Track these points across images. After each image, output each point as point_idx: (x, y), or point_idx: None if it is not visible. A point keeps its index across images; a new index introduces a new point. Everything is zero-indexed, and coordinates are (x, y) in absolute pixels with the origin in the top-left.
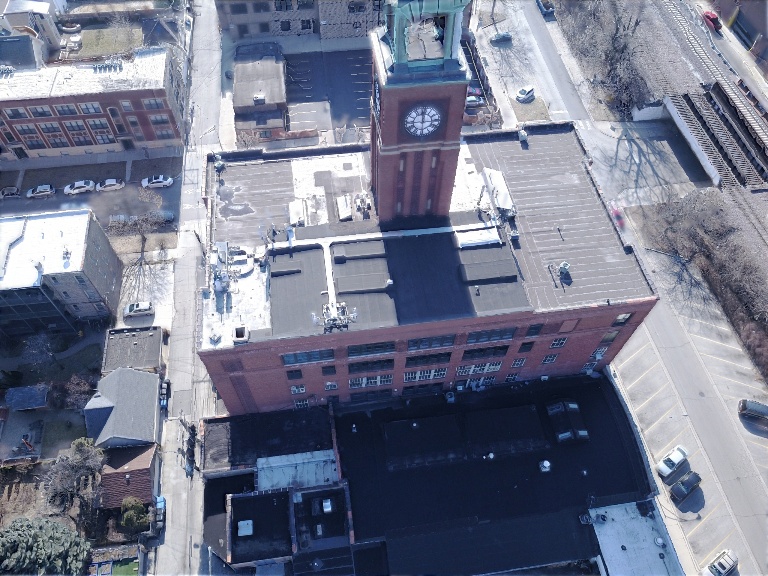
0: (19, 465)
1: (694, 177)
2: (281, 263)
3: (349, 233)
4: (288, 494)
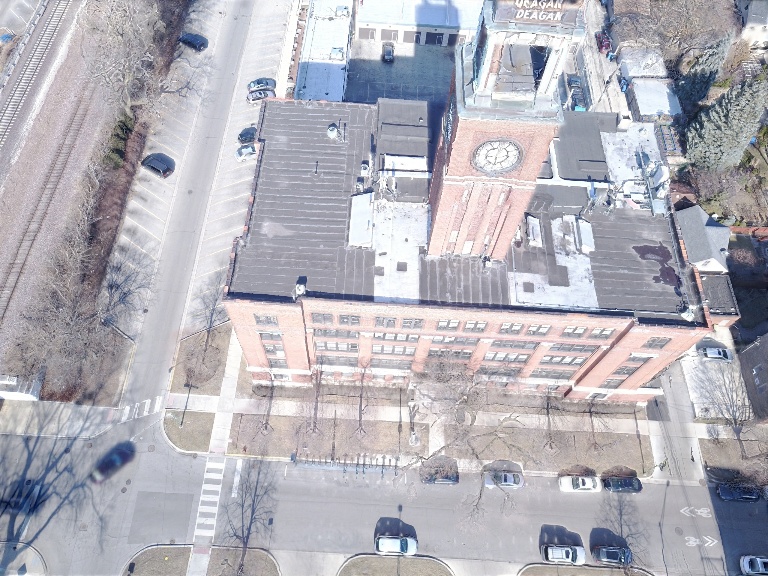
0: (764, 225)
1: None
2: (599, 169)
3: None
4: None
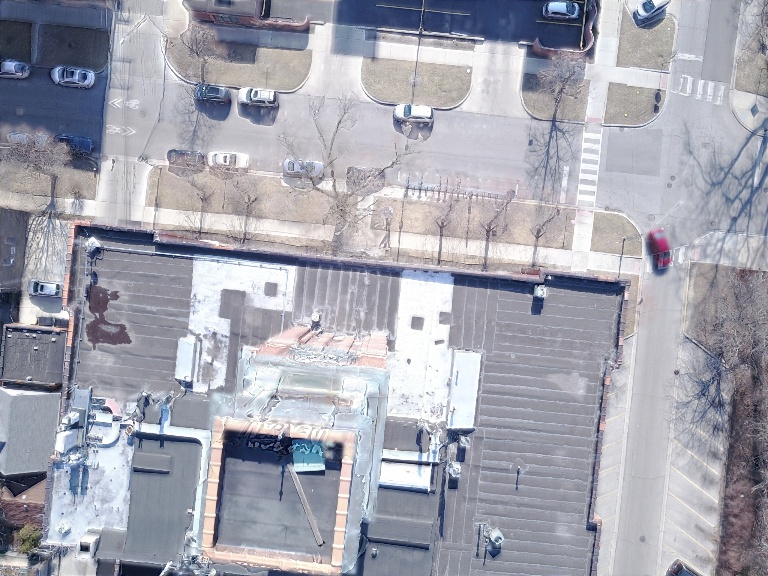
0: None
1: None
2: (146, 456)
3: None
4: (173, 572)
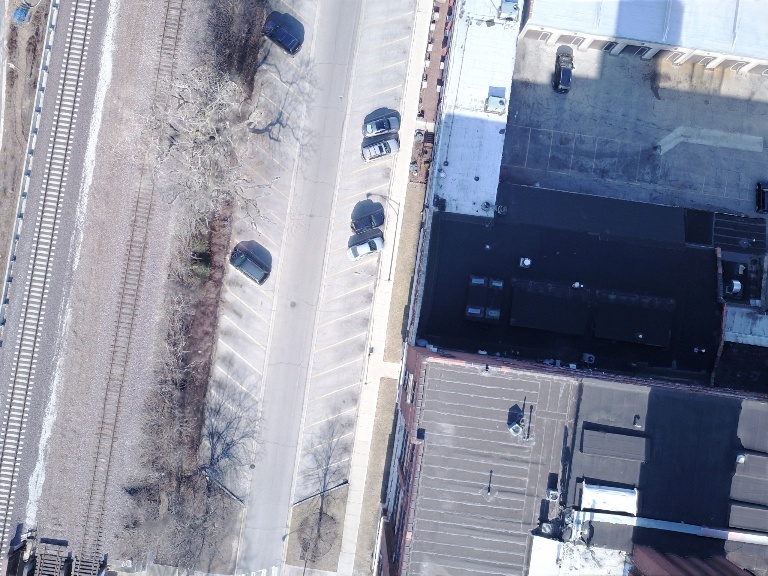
0: None
1: None
2: None
3: (766, 551)
4: None
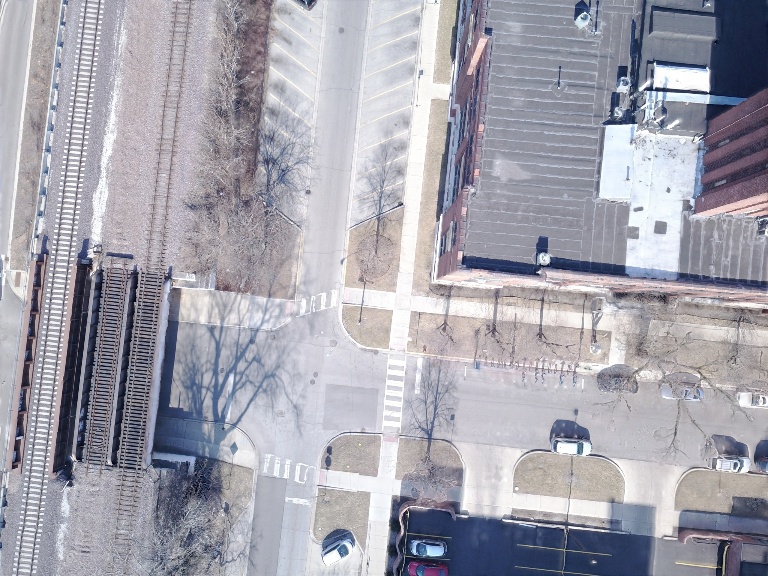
0: None
1: (169, 330)
2: None
3: None
4: None
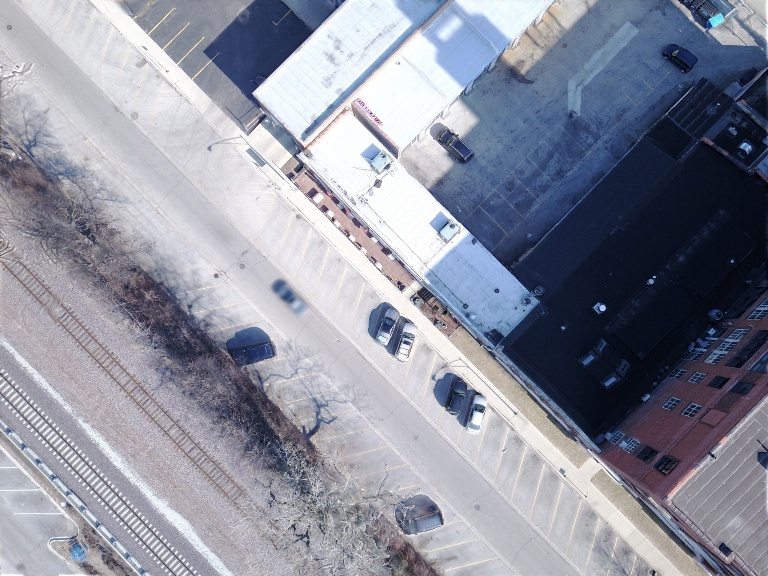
0: None
1: None
2: None
3: None
4: None
